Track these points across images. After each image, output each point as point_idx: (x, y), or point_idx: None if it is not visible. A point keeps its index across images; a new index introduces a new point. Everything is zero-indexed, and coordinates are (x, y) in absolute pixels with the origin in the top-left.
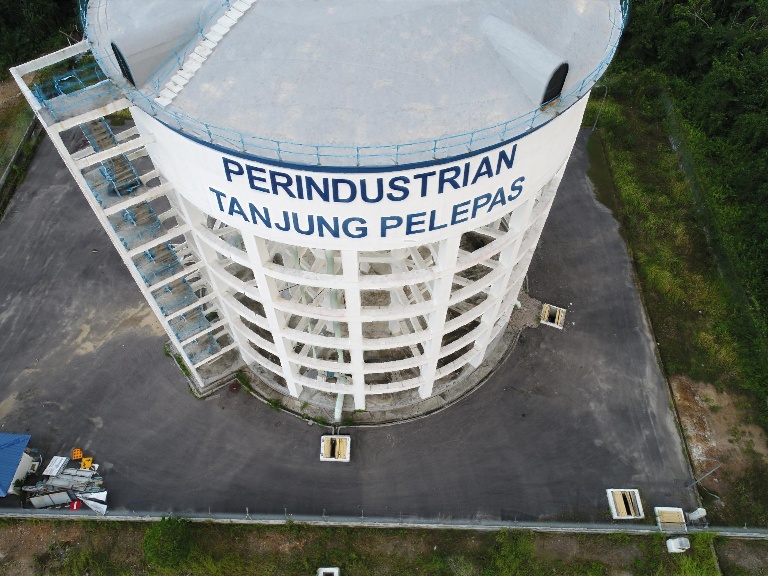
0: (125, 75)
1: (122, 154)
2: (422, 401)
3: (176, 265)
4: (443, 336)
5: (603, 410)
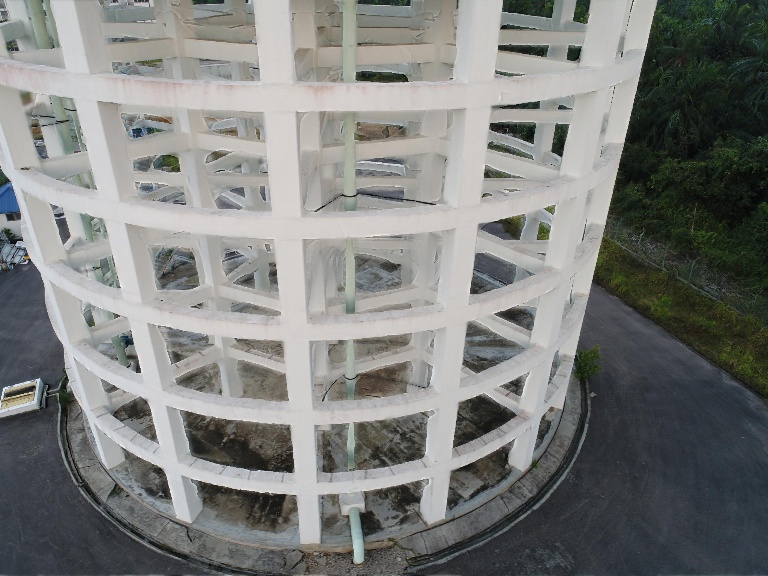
0: None
1: None
2: (102, 465)
3: None
4: (239, 455)
5: None
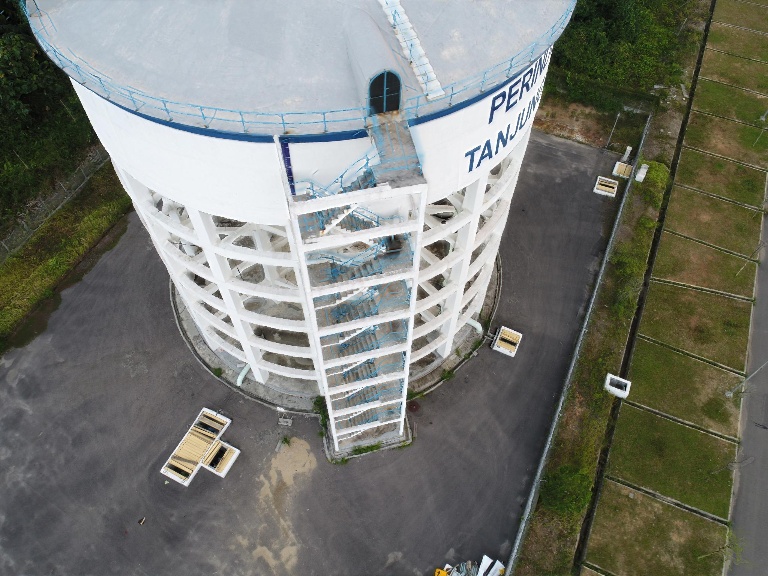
0: (377, 110)
1: (362, 221)
2: None
3: None
4: None
5: (536, 167)
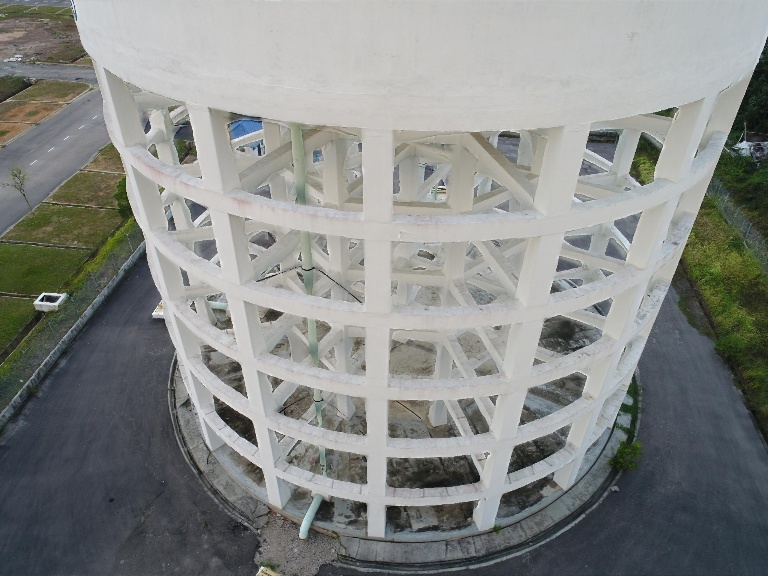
0: None
1: None
2: None
3: None
4: None
5: None
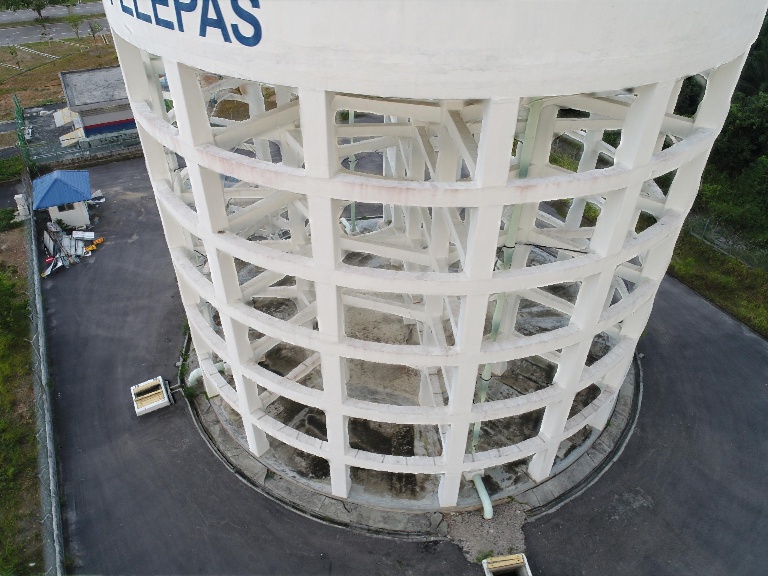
0: None
1: None
2: (249, 453)
3: None
4: (364, 435)
5: None
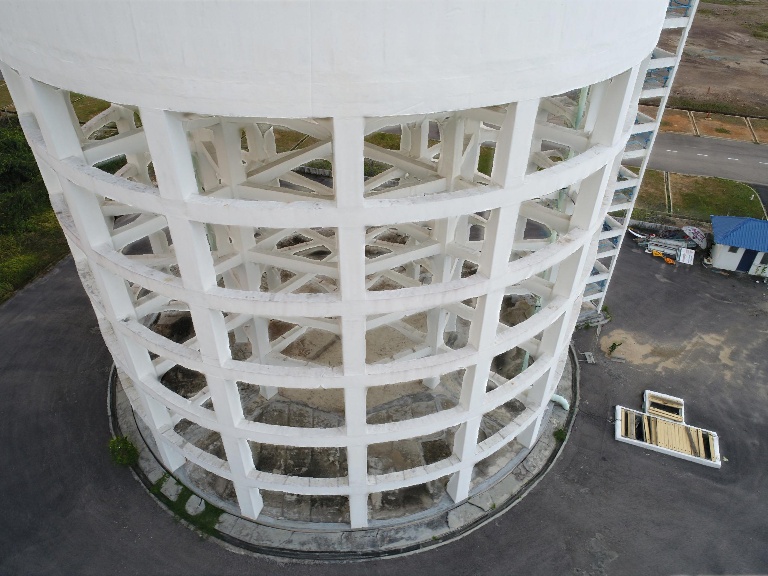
0: None
1: None
2: None
3: (576, 99)
4: None
5: None
